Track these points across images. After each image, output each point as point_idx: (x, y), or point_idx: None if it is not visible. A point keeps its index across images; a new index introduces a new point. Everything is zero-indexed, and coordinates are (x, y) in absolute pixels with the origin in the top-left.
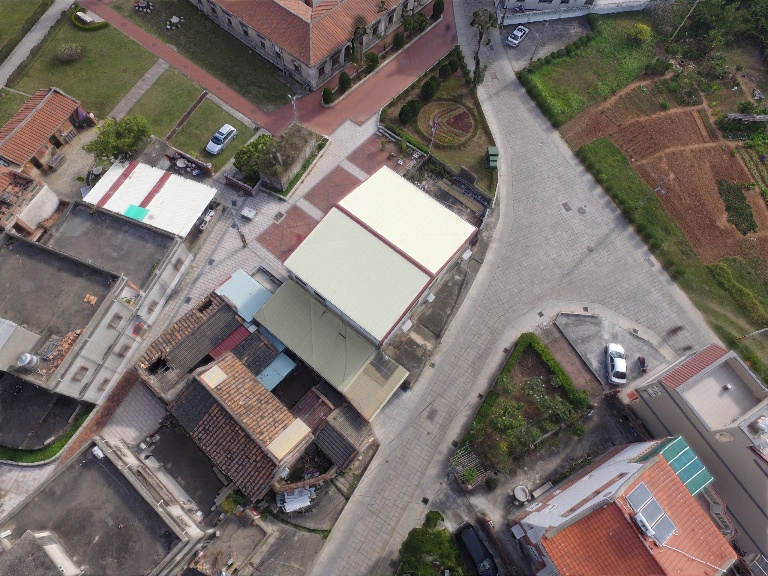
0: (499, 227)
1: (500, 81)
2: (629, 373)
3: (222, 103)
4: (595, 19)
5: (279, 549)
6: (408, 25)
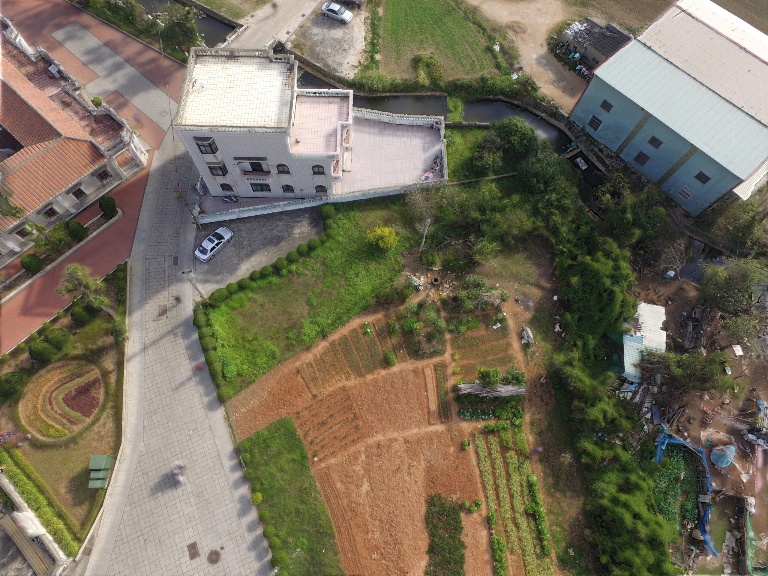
0: None
1: (169, 320)
2: None
3: None
4: (327, 215)
5: None
6: (38, 246)
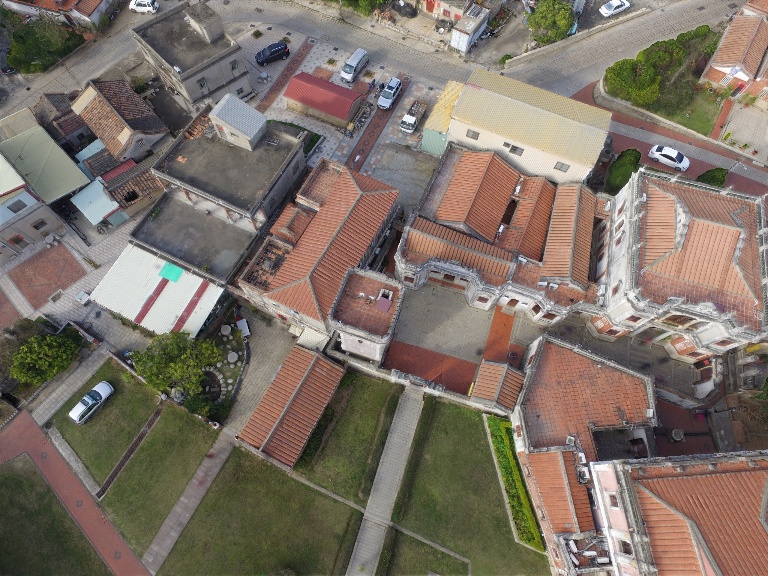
0: None
1: None
2: None
3: (82, 474)
4: None
5: None
6: None
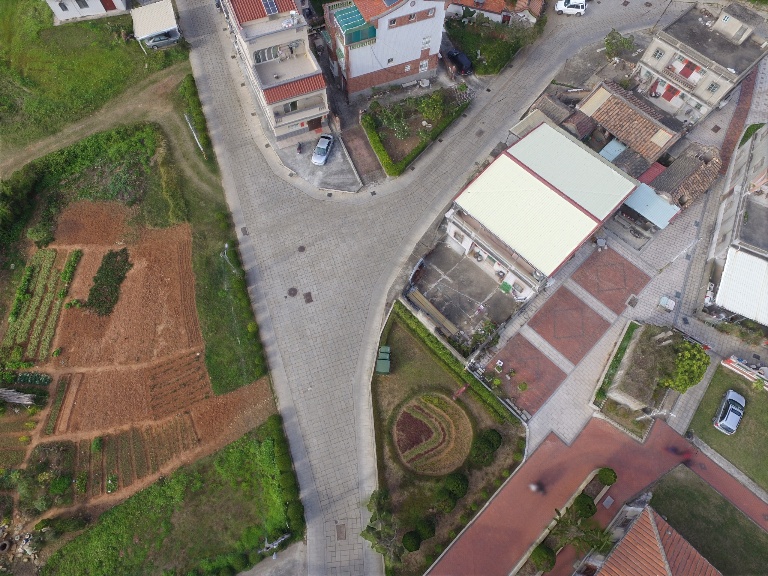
0: (392, 279)
1: (334, 518)
2: (313, 146)
3: (752, 487)
4: None
5: (582, 78)
6: None
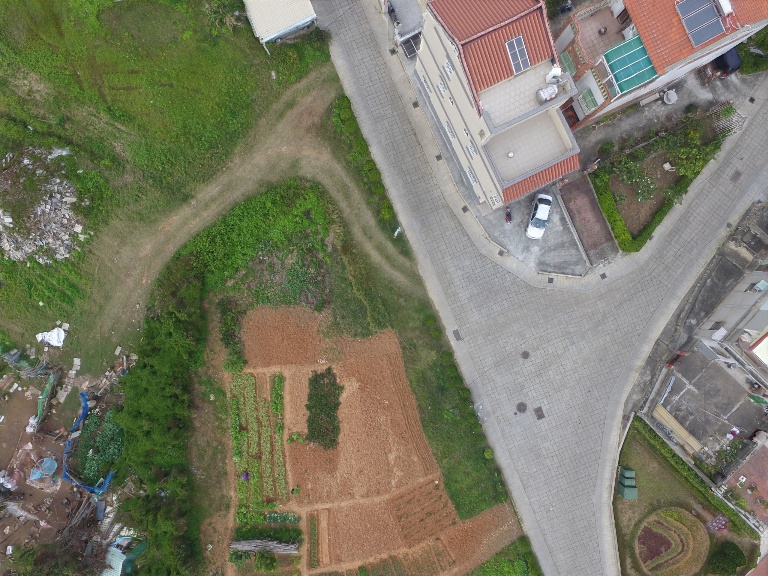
0: (629, 387)
1: None
2: (523, 208)
3: None
4: None
5: None
6: None
